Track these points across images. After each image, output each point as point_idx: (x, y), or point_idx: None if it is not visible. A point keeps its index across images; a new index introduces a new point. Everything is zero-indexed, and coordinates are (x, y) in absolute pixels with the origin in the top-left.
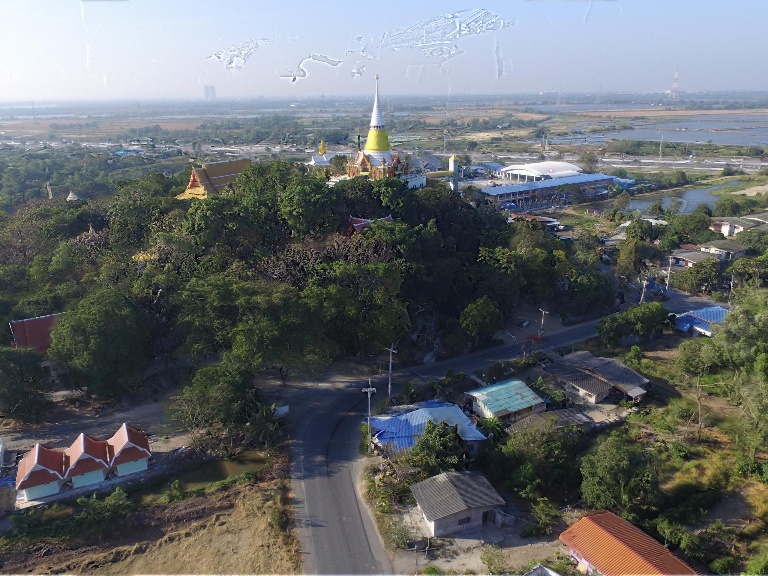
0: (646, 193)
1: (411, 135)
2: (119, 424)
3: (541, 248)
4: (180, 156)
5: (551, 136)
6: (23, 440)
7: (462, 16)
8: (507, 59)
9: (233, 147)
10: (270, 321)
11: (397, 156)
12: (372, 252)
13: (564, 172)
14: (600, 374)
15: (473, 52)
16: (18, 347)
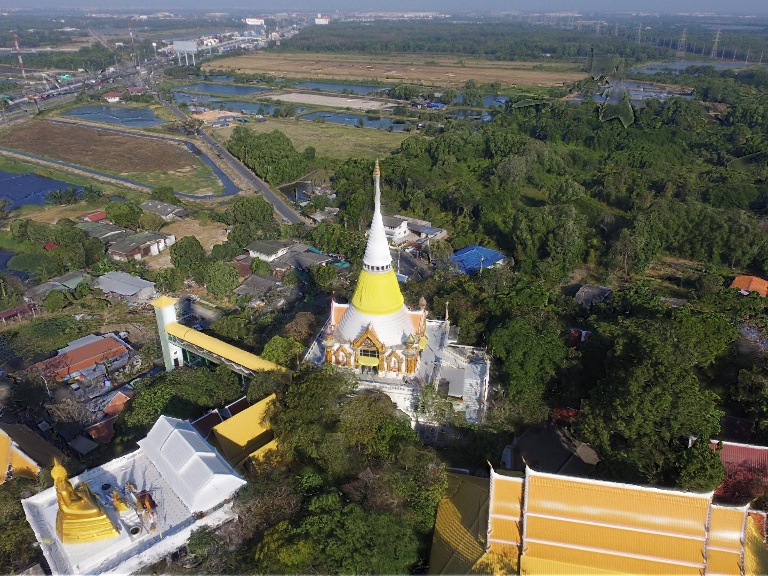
0: None
1: None
2: None
3: None
4: None
5: None
6: None
7: None
8: None
9: None
10: None
11: None
12: None
13: None
14: None
15: None
16: None
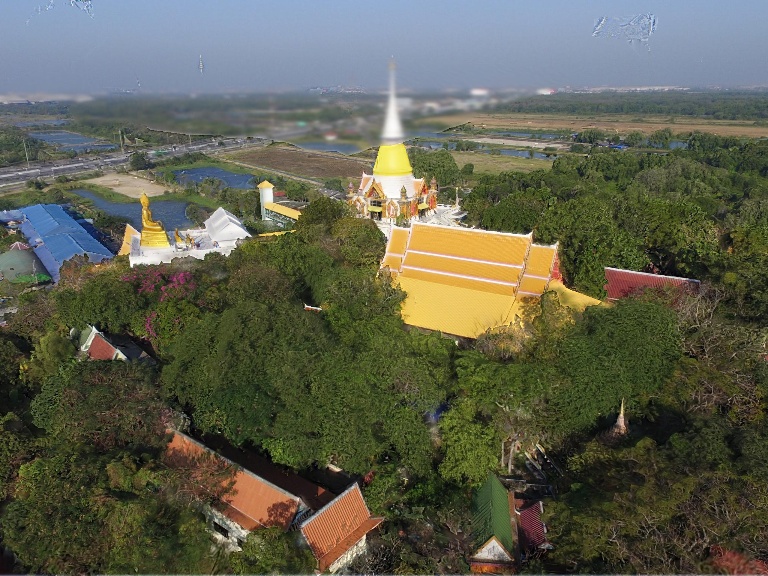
0: None
1: None
2: None
3: None
4: None
5: None
6: None
7: None
8: None
9: None
10: None
11: None
12: None
13: None
14: None
15: None
16: None
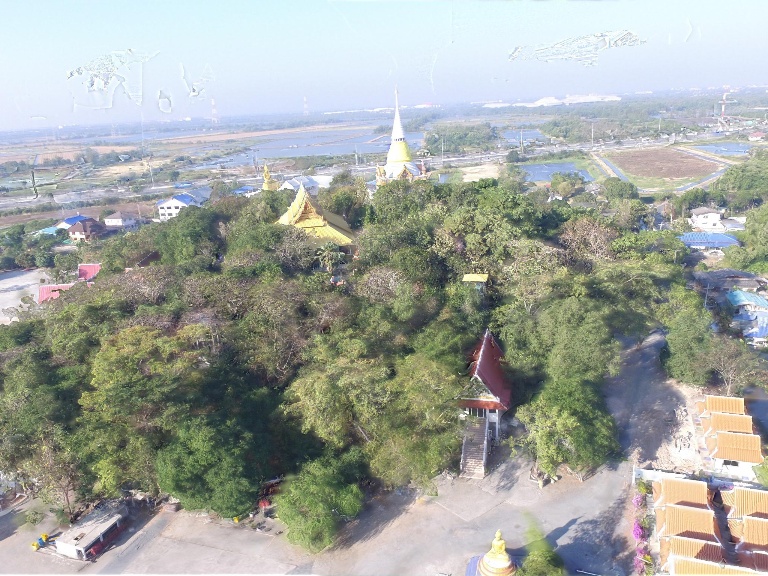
0: None
1: (28, 178)
2: (634, 419)
3: None
4: None
5: (199, 162)
6: (621, 465)
7: (611, 35)
8: None
9: None
10: (679, 285)
11: None
12: None
13: None
14: (742, 276)
15: (159, 78)
16: (498, 397)
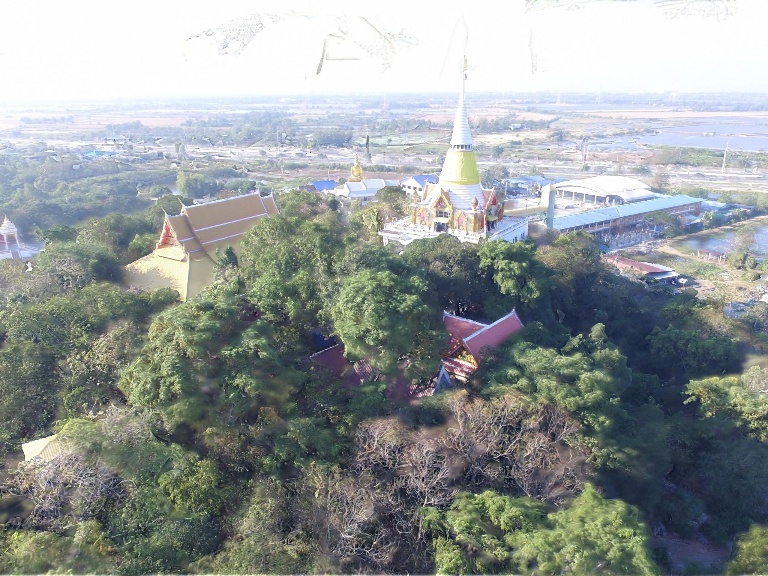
0: (744, 221)
1: (417, 136)
2: None
3: (764, 364)
4: (160, 160)
5: (573, 140)
6: None
7: None
8: (542, 53)
9: (222, 149)
10: None
11: (493, 193)
12: (548, 444)
13: (634, 191)
14: None
15: (503, 44)
16: None
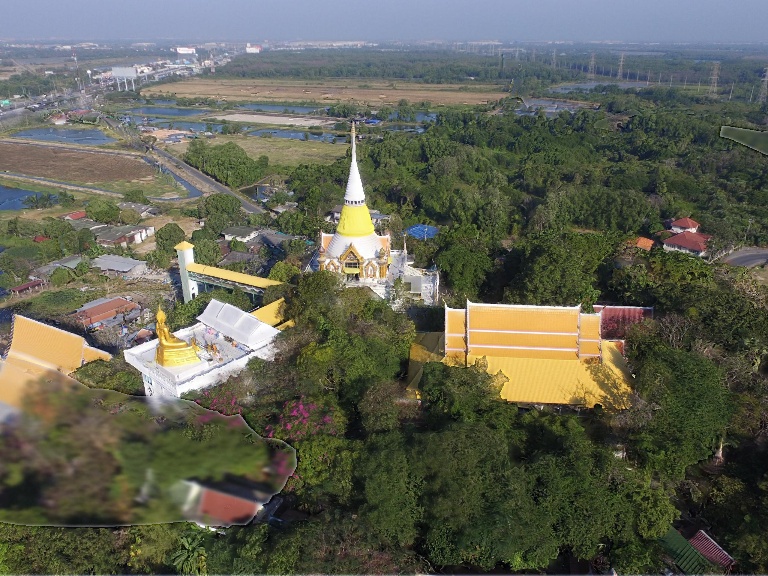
0: None
1: None
2: None
3: None
4: None
5: None
6: None
7: None
8: None
9: None
10: None
11: None
12: None
13: None
14: None
15: None
16: None
